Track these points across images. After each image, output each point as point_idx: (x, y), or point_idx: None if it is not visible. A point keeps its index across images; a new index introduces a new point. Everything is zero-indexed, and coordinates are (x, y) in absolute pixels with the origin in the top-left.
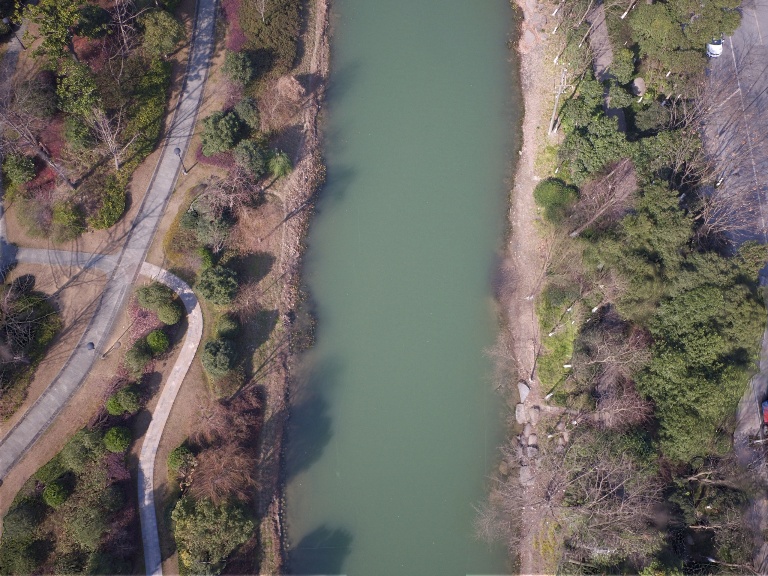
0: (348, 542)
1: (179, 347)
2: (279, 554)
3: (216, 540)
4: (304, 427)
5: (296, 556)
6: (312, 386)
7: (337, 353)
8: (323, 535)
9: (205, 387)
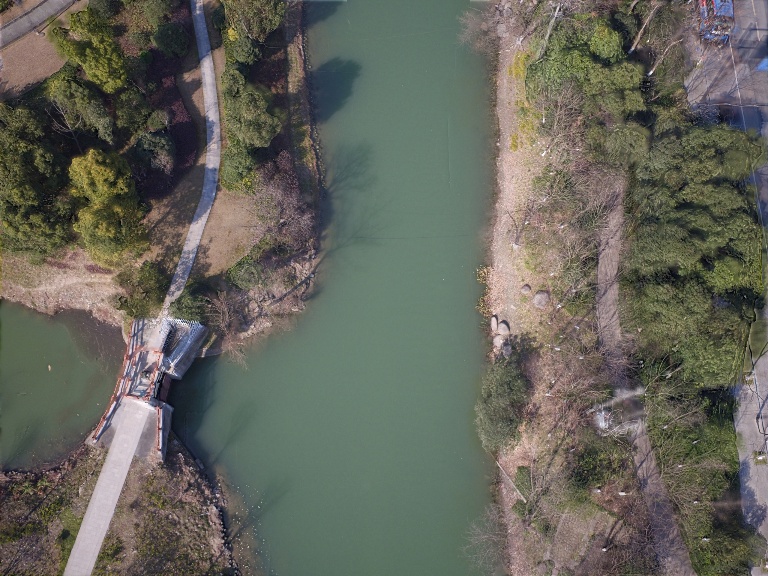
0: (358, 70)
1: None
2: (303, 69)
3: (256, 4)
4: None
5: (316, 75)
6: None
7: None
8: (338, 63)
9: None
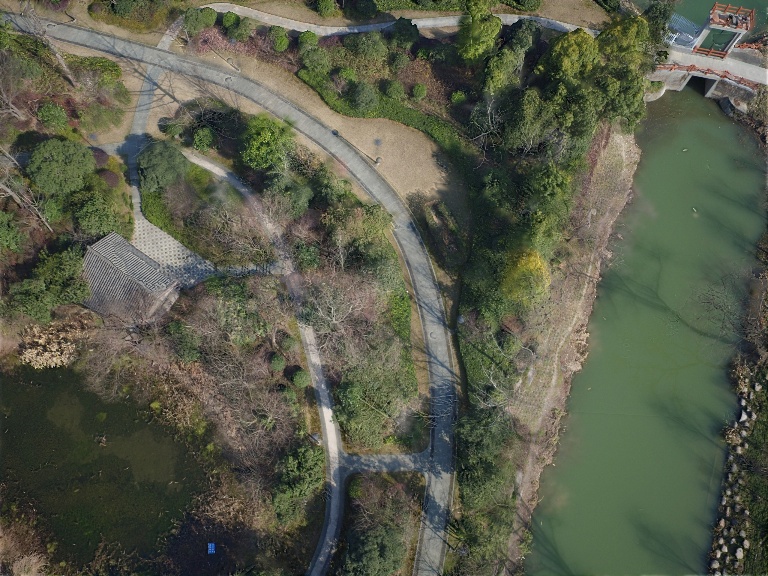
0: None
1: None
2: None
3: None
4: None
5: None
6: None
7: None
8: None
9: (271, 2)
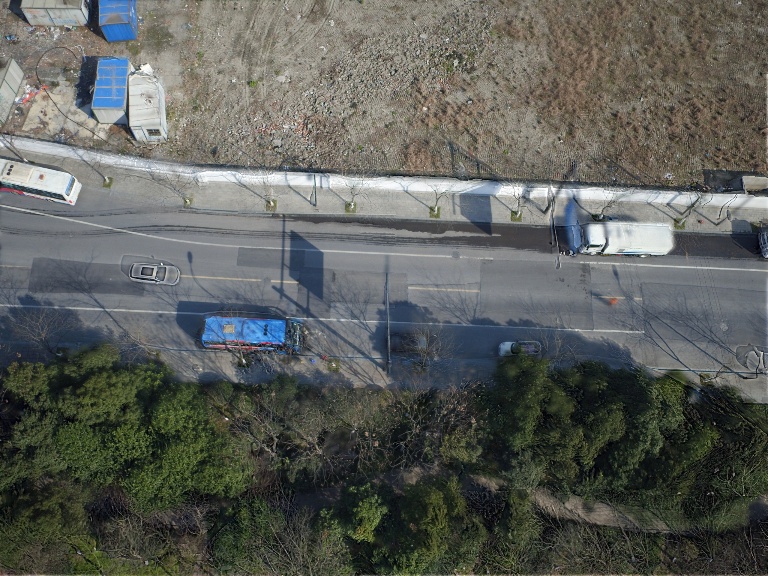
0: None
1: None
2: None
3: None
4: None
5: None
6: None
7: None
8: None
9: None
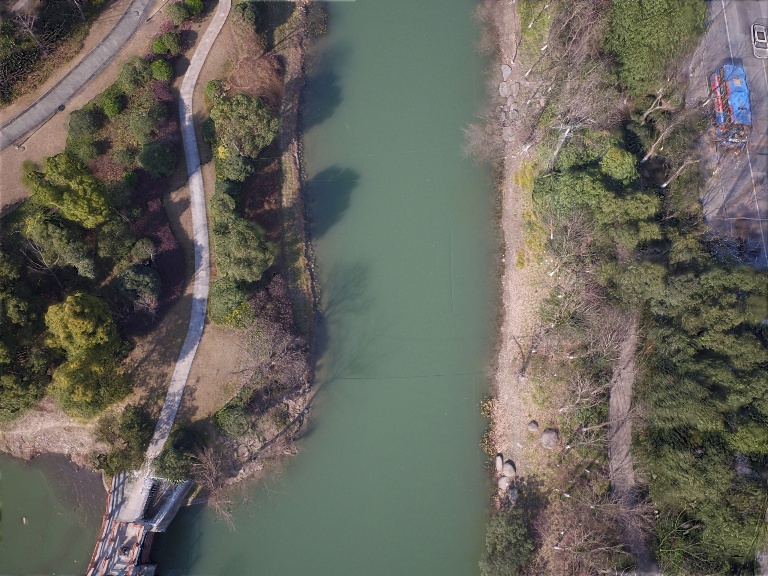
0: (356, 178)
1: (211, 15)
2: (298, 180)
3: (248, 124)
4: (318, 92)
5: (312, 185)
6: (324, 63)
7: (346, 39)
8: (335, 171)
9: (234, 46)
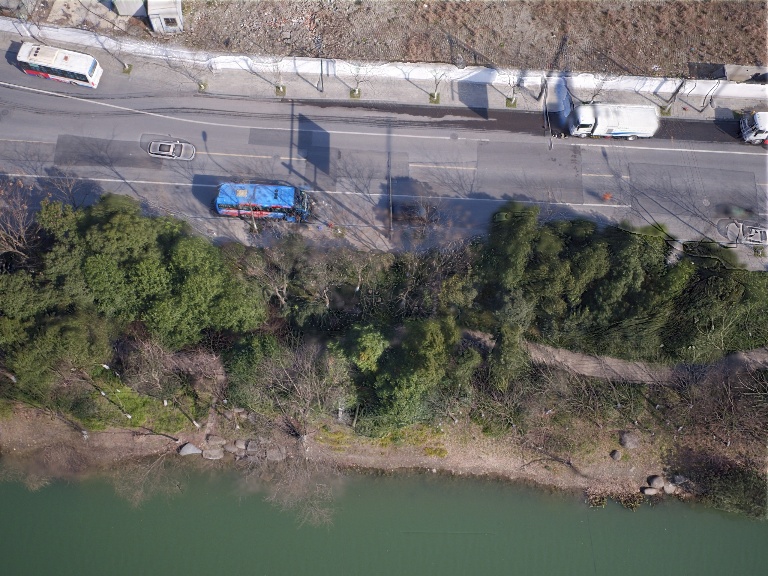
0: None
1: None
2: None
3: None
4: None
5: None
6: None
7: None
8: None
9: None
